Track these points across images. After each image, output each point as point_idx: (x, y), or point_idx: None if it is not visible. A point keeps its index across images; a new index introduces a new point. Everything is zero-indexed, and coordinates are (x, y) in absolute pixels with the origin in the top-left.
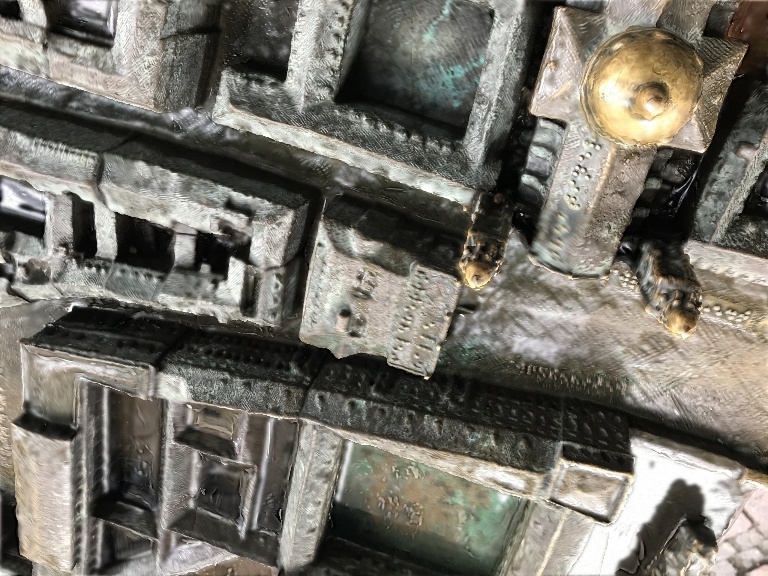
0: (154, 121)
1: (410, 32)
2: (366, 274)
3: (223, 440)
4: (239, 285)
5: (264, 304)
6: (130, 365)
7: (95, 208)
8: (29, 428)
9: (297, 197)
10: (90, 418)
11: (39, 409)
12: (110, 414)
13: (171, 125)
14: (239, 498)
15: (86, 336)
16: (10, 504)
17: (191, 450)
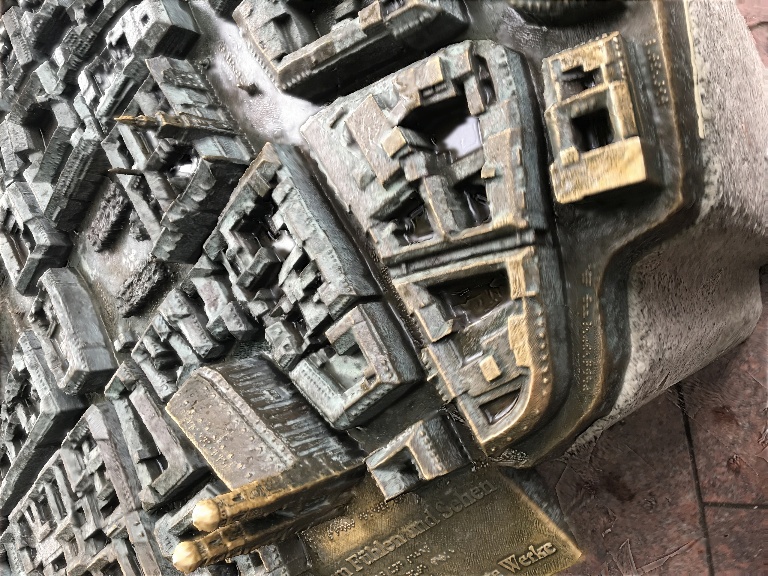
0: None
1: None
2: None
3: None
4: None
5: None
6: None
7: None
8: None
9: None
10: None
11: None
12: None
13: None
14: None
15: None
16: None
17: None
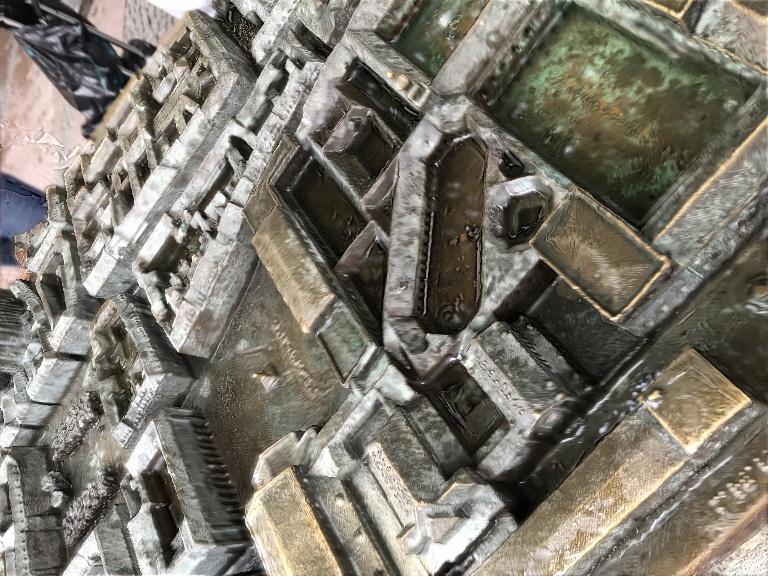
0: None
1: None
2: None
3: None
4: None
5: None
6: None
7: None
8: None
9: None
10: (293, 212)
11: None
12: (316, 226)
13: None
14: None
15: None
16: None
17: None
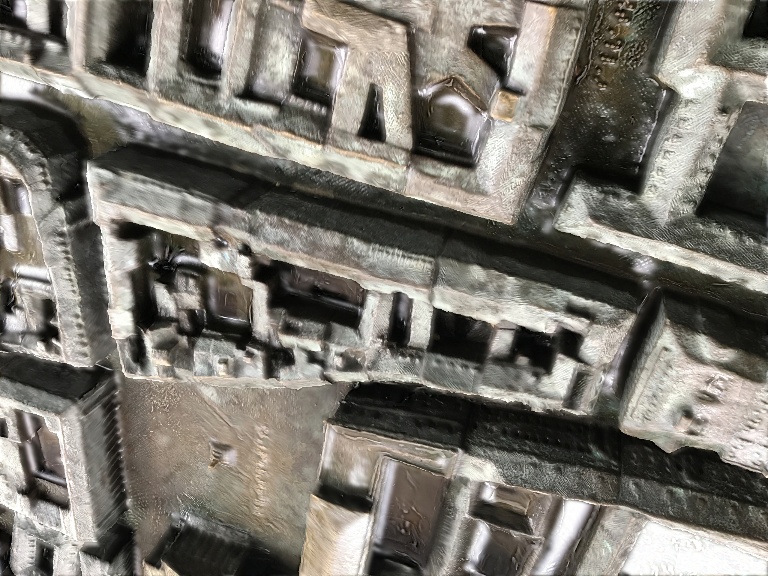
0: (467, 217)
1: (765, 139)
2: (716, 379)
3: (515, 514)
4: (566, 380)
5: (587, 397)
6: (439, 448)
7: (414, 303)
8: (330, 500)
9: (627, 296)
10: None
11: (334, 480)
12: None
13: (484, 221)
14: (509, 561)
15: (381, 414)
16: (257, 548)
17: (475, 520)
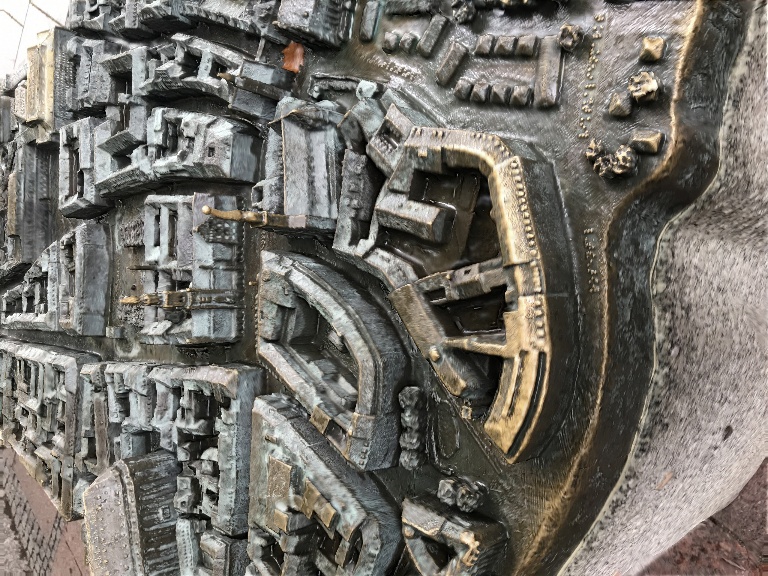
0: None
1: None
2: None
3: None
4: (3, 305)
5: None
6: None
7: None
8: None
9: None
10: None
11: None
12: None
13: None
14: None
15: (27, 266)
16: None
17: None
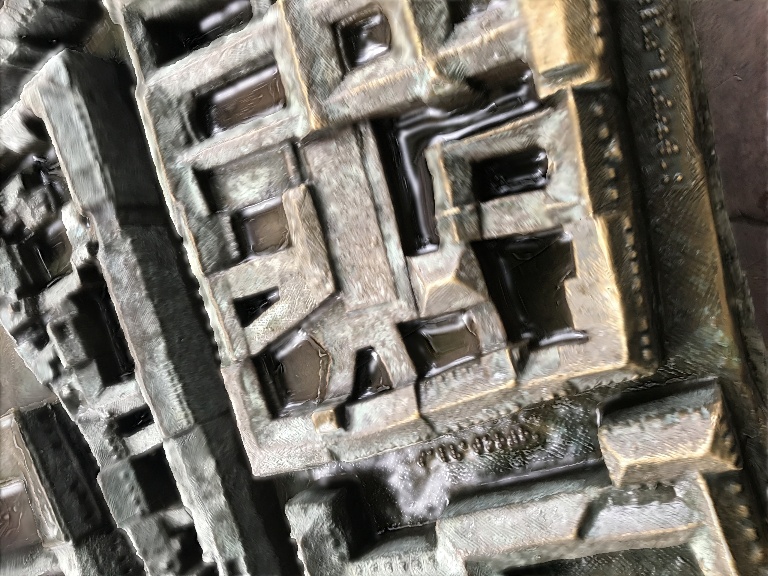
0: None
1: None
2: None
3: None
4: None
5: None
6: (60, 525)
7: None
8: None
9: None
10: None
11: None
12: None
13: None
14: None
15: (61, 448)
16: None
17: None
